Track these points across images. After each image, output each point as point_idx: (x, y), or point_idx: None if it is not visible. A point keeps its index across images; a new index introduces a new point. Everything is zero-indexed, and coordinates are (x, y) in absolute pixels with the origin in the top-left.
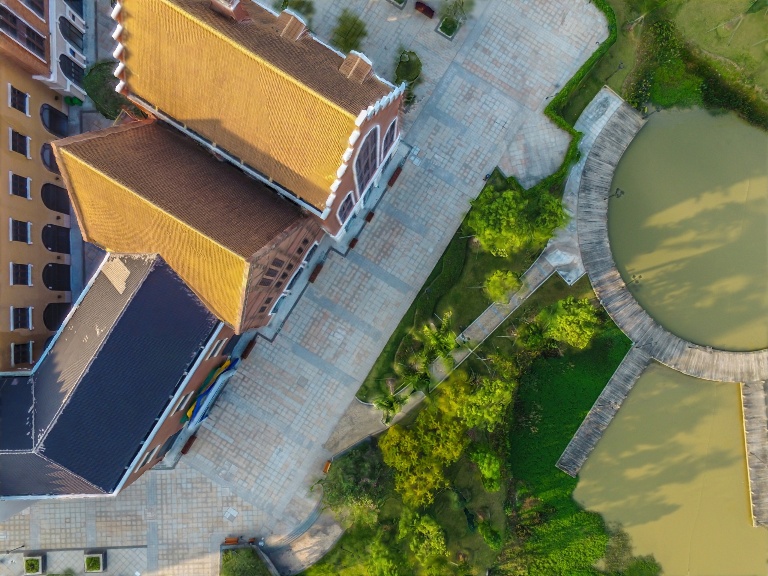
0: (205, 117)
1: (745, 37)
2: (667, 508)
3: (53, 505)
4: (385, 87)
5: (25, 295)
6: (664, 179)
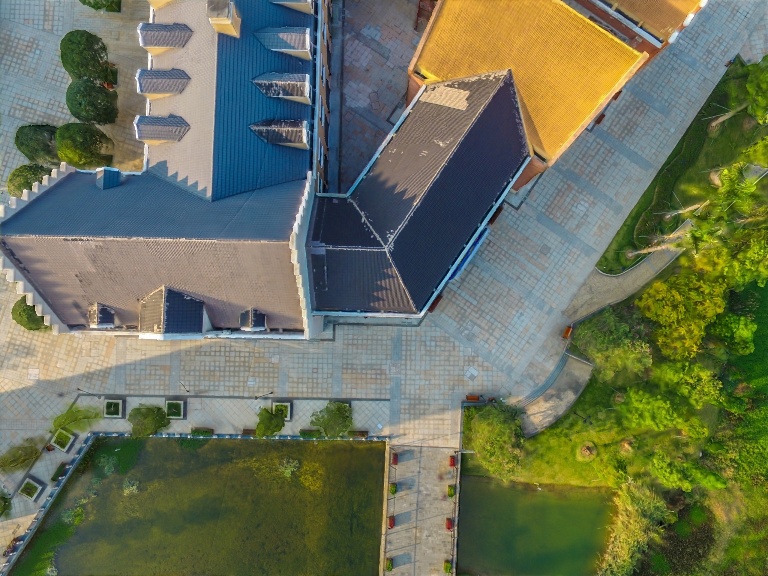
0: None
1: None
2: None
3: (302, 355)
4: None
5: (321, 133)
6: None
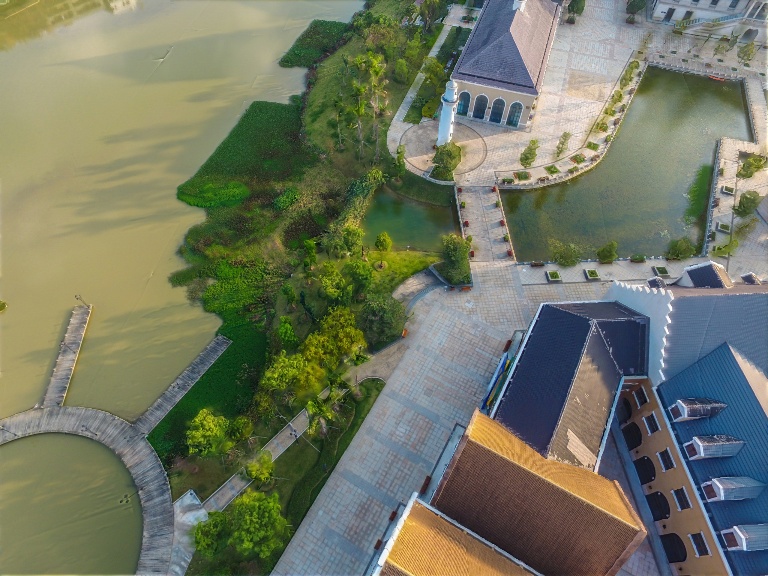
0: None
1: None
2: (153, 316)
3: None
4: None
5: (657, 444)
6: None
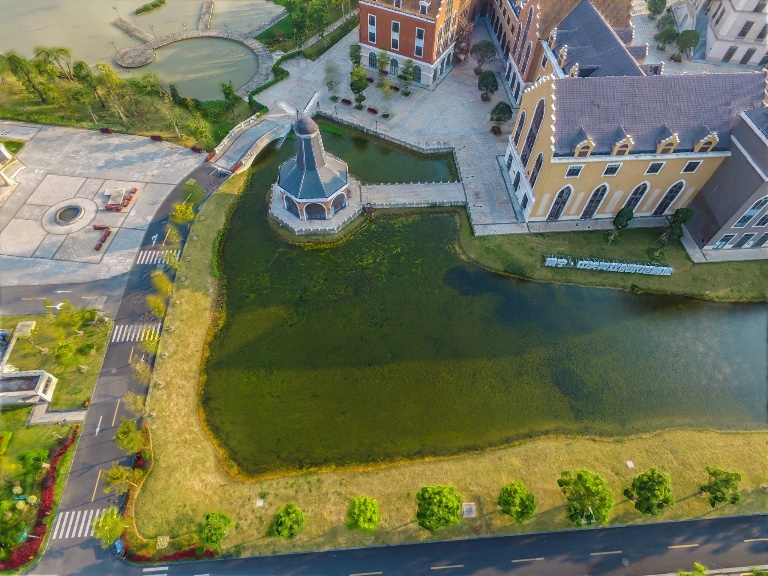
0: None
1: None
2: (248, 5)
3: None
4: None
5: None
6: None
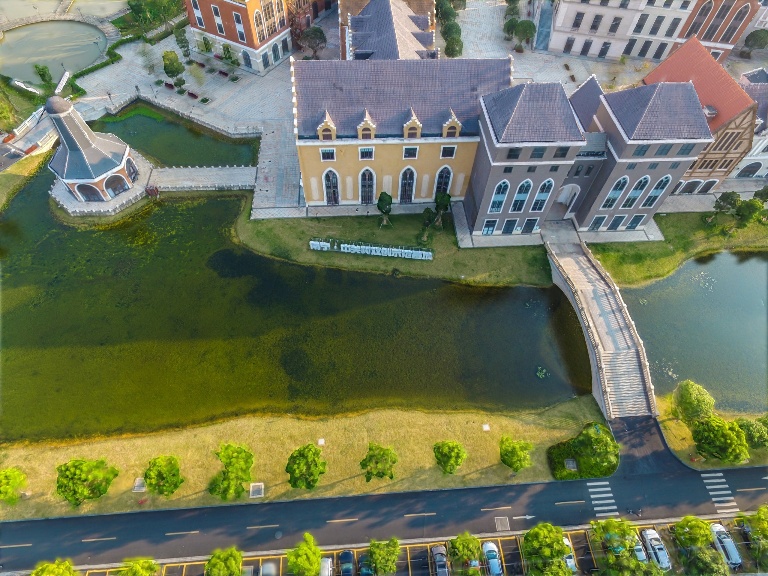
0: None
1: None
2: None
3: None
4: None
5: None
6: None
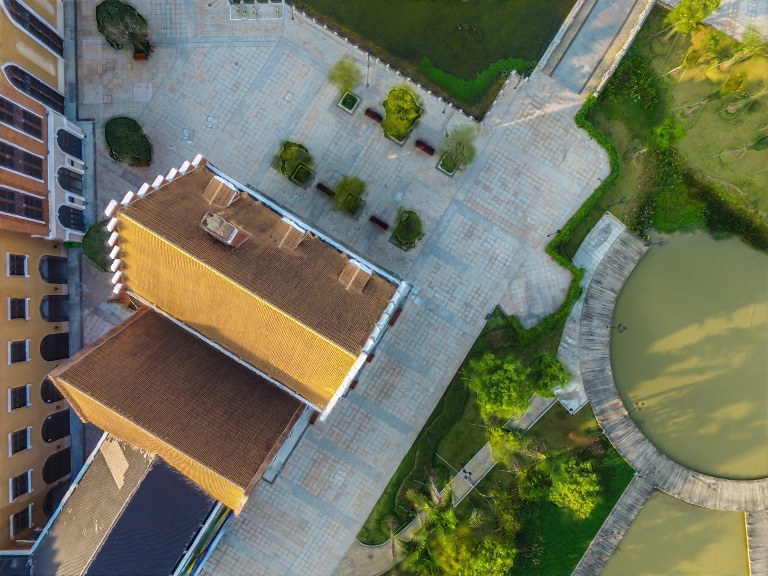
0: (203, 323)
1: (748, 164)
2: None
3: None
4: (385, 288)
5: (24, 460)
6: (667, 303)
